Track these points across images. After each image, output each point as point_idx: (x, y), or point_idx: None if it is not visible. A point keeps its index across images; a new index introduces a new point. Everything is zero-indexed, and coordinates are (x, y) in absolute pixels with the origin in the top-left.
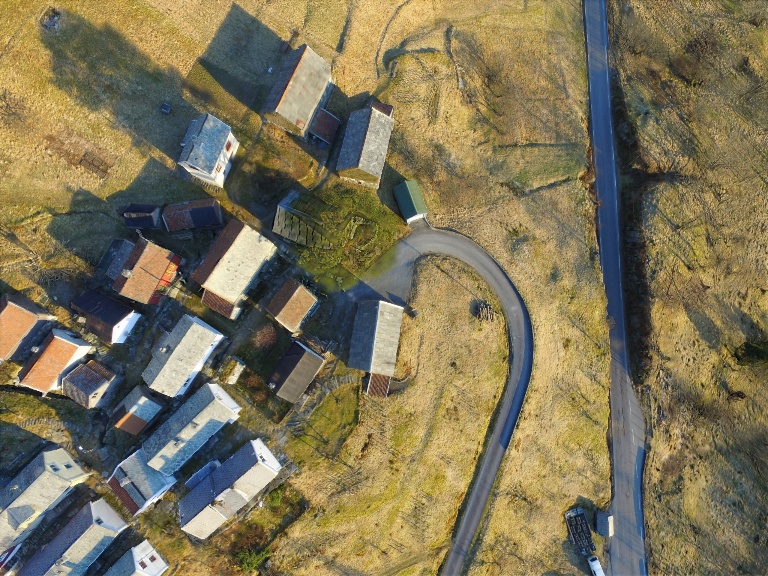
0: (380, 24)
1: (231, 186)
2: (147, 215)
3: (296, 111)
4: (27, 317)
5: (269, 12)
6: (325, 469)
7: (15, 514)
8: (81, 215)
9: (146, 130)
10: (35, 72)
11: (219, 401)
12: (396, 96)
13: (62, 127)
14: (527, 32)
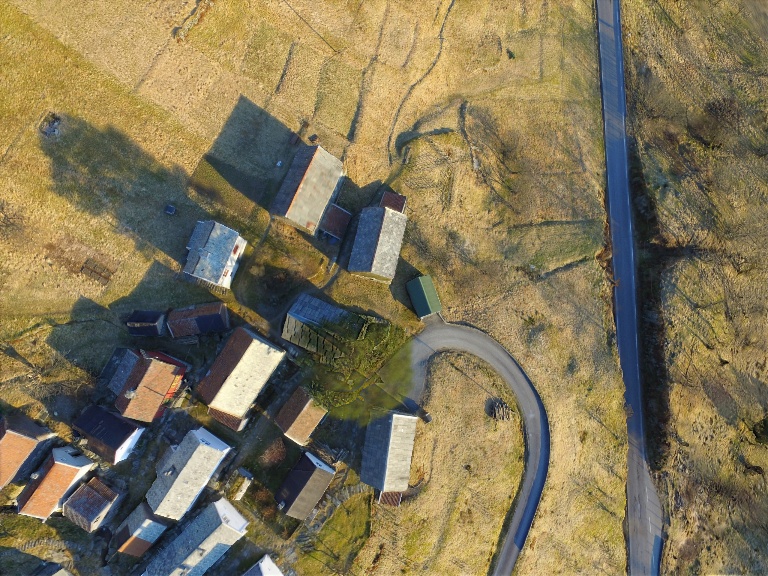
0: (392, 106)
1: (238, 287)
2: (151, 325)
3: (306, 213)
4: (26, 443)
5: (278, 102)
6: None
7: None
8: (82, 324)
9: (150, 232)
10: (34, 181)
11: (226, 525)
12: (409, 183)
13: (62, 234)
14: (543, 103)
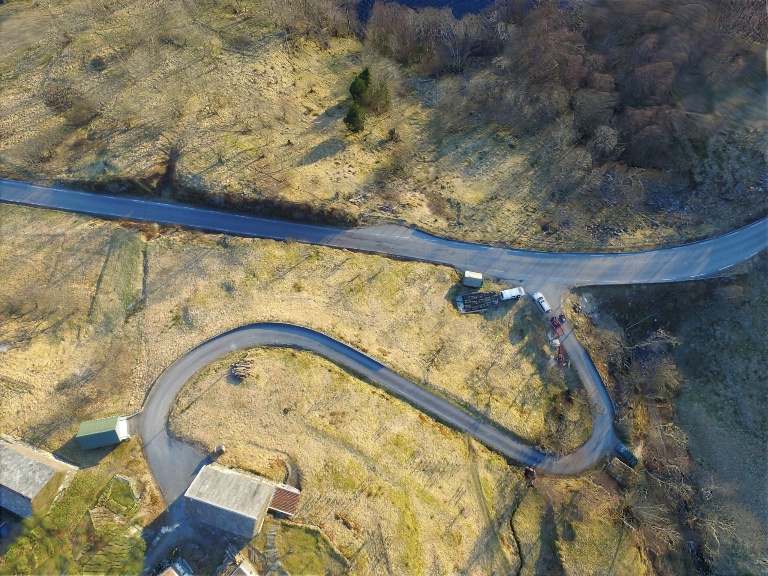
0: None
1: None
2: None
3: None
4: None
5: None
6: (359, 575)
7: None
8: None
9: None
10: None
11: None
12: None
13: None
14: None
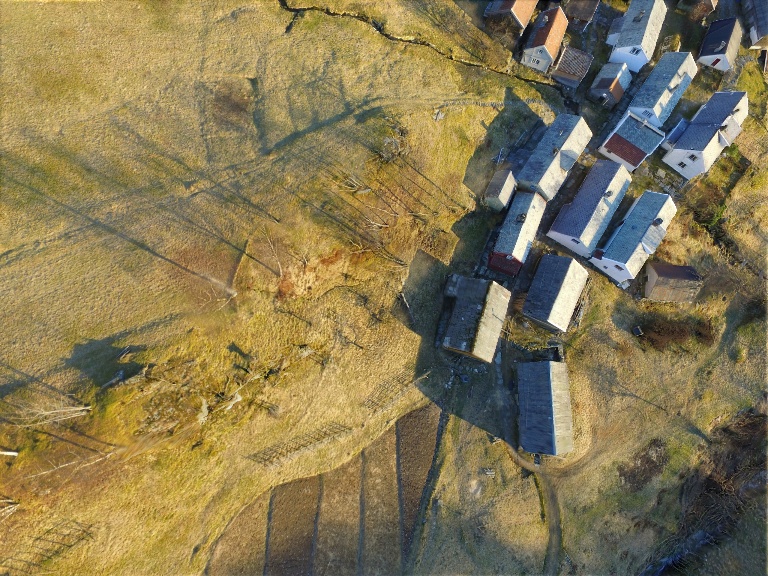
0: None
1: None
2: None
3: None
4: None
5: None
6: (754, 132)
7: (568, 154)
8: None
9: None
10: None
11: None
12: None
13: None
14: None
